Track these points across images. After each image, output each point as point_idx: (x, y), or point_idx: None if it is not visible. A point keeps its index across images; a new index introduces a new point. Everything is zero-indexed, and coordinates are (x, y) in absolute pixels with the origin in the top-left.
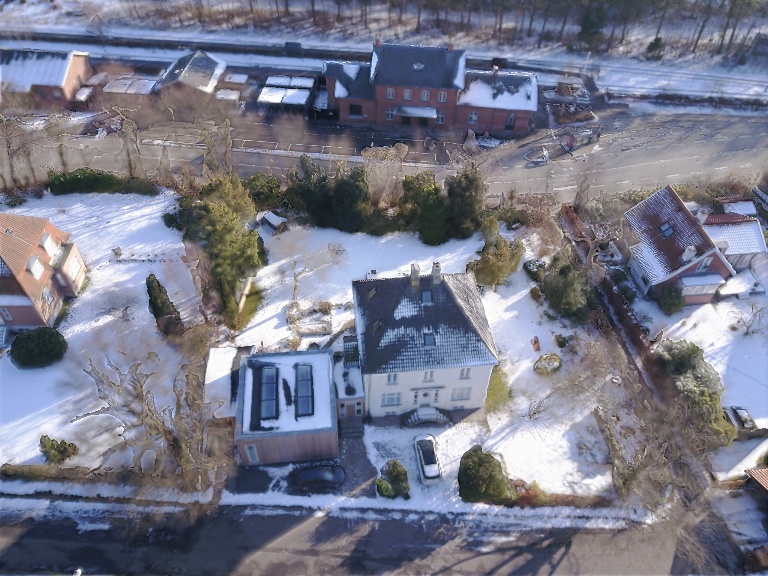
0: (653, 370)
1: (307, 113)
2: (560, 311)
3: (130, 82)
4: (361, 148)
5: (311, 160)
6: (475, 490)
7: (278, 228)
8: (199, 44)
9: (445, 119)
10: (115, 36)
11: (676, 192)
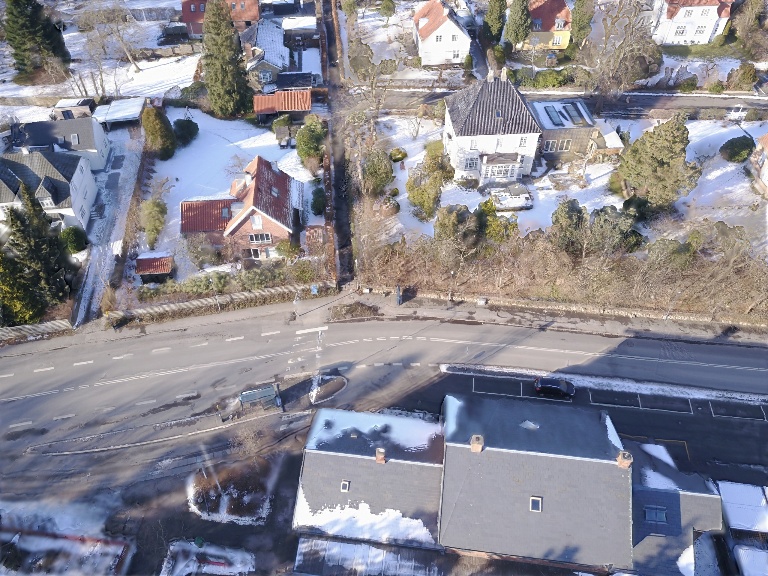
0: None
1: None
2: None
3: None
4: (584, 404)
5: (622, 226)
6: None
7: None
8: None
9: None
10: None
11: (208, 274)
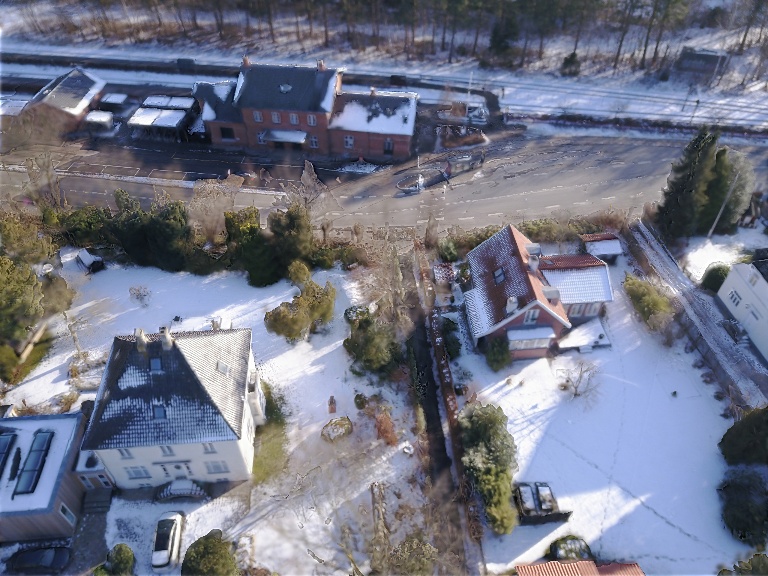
0: (453, 438)
1: (179, 136)
2: (363, 368)
3: (3, 103)
4: (225, 174)
5: (127, 195)
6: None
7: None
8: (93, 60)
9: (319, 143)
10: (11, 52)
11: (538, 228)
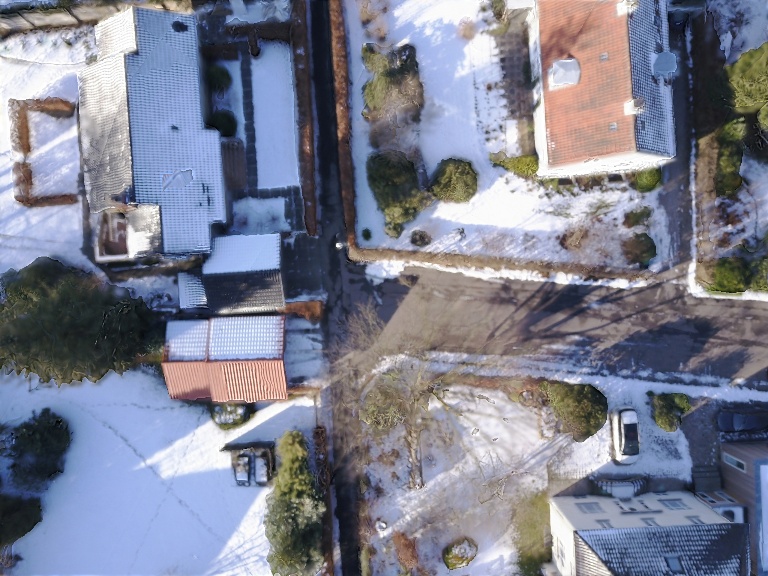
0: None
1: None
2: None
3: None
4: None
5: None
6: (592, 390)
7: None
8: None
9: None
10: None
11: None
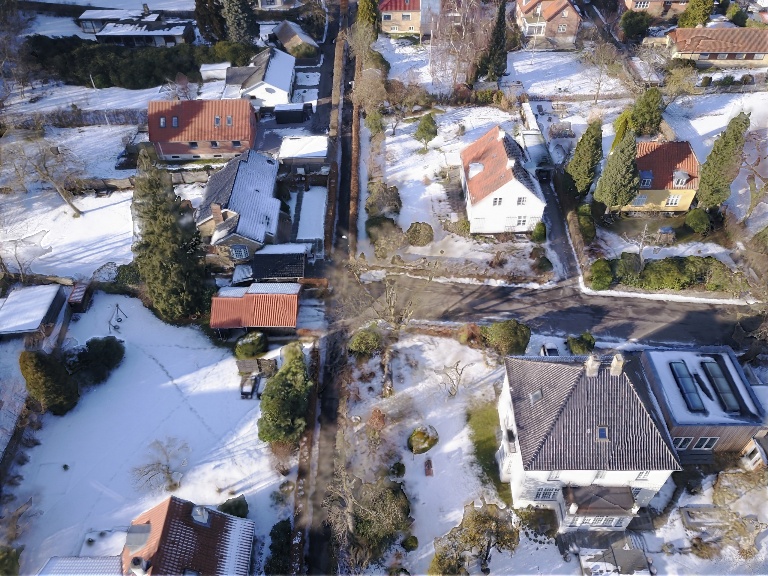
0: None
1: None
2: None
3: None
4: None
5: None
6: None
7: None
8: None
9: None
10: None
11: None
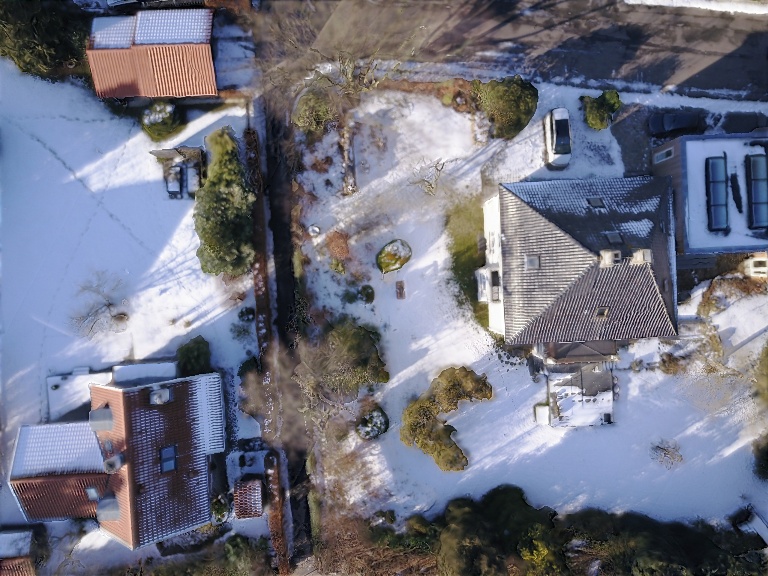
0: None
1: None
2: None
3: None
4: None
5: None
6: None
7: (748, 514)
8: None
9: None
10: None
11: None
